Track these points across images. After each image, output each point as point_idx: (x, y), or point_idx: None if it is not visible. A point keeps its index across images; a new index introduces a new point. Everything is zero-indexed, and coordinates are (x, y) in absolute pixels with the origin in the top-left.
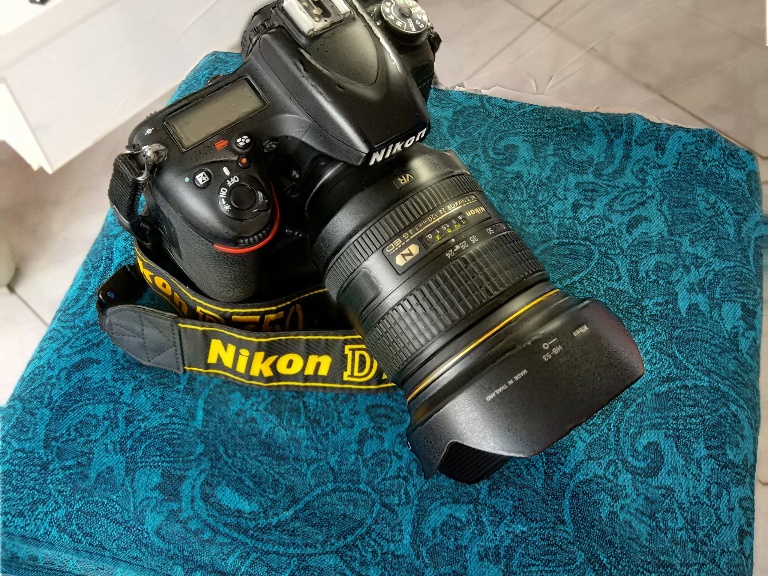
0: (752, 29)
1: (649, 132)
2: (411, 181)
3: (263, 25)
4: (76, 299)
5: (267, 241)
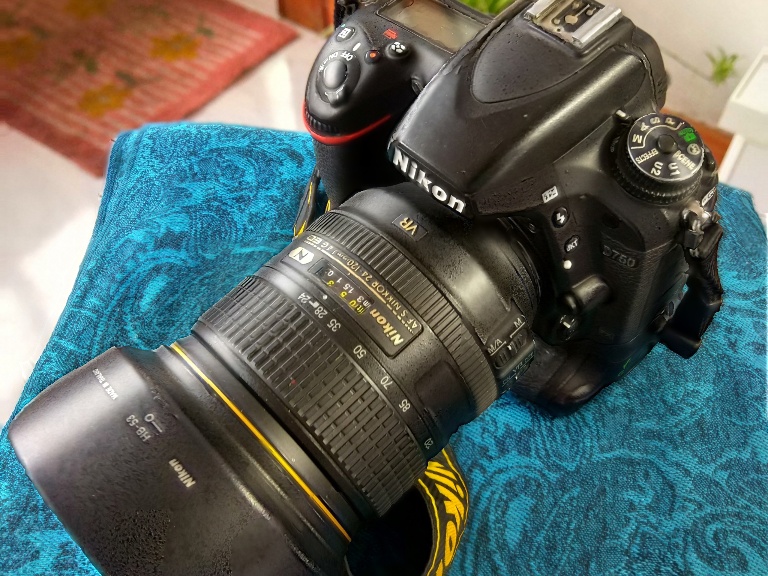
0: None
1: None
2: (408, 234)
3: None
4: None
5: (321, 140)
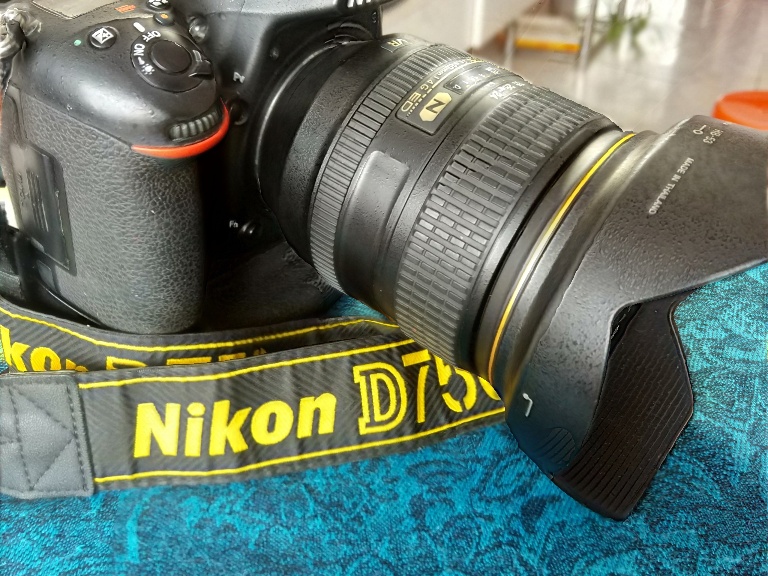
0: (661, 69)
1: None
2: (405, 45)
3: None
4: None
5: (216, 141)
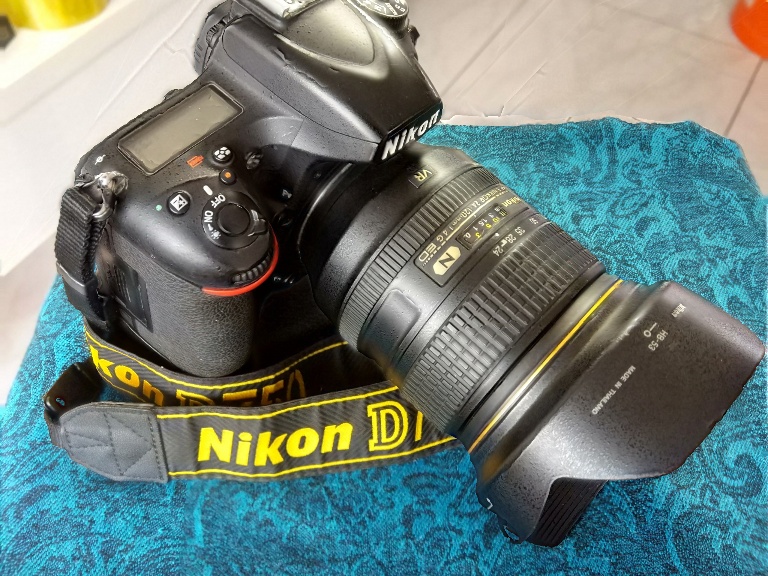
0: (699, 24)
1: (630, 133)
2: (430, 177)
3: (221, 23)
4: (14, 417)
5: (268, 275)
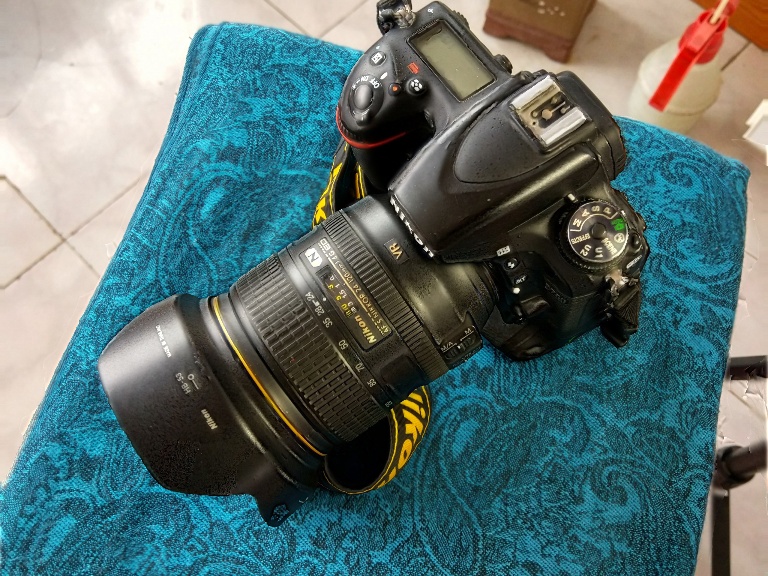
0: None
1: None
2: (394, 257)
3: None
4: None
5: None
